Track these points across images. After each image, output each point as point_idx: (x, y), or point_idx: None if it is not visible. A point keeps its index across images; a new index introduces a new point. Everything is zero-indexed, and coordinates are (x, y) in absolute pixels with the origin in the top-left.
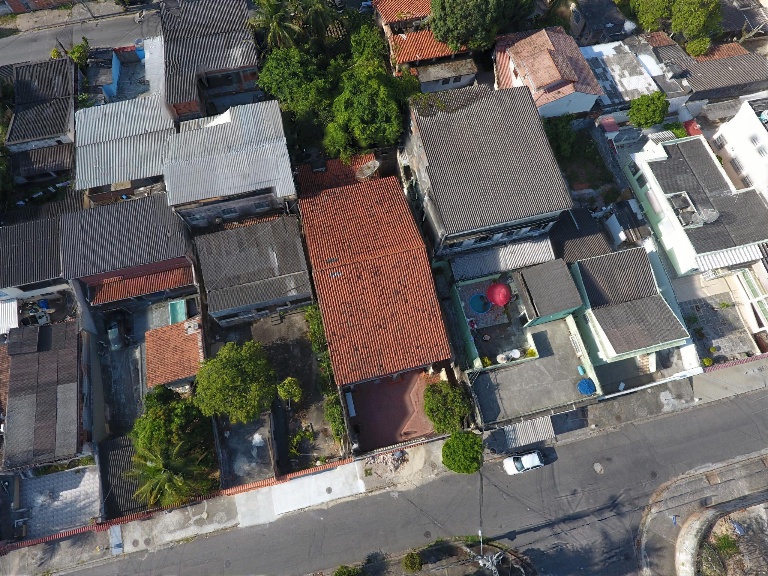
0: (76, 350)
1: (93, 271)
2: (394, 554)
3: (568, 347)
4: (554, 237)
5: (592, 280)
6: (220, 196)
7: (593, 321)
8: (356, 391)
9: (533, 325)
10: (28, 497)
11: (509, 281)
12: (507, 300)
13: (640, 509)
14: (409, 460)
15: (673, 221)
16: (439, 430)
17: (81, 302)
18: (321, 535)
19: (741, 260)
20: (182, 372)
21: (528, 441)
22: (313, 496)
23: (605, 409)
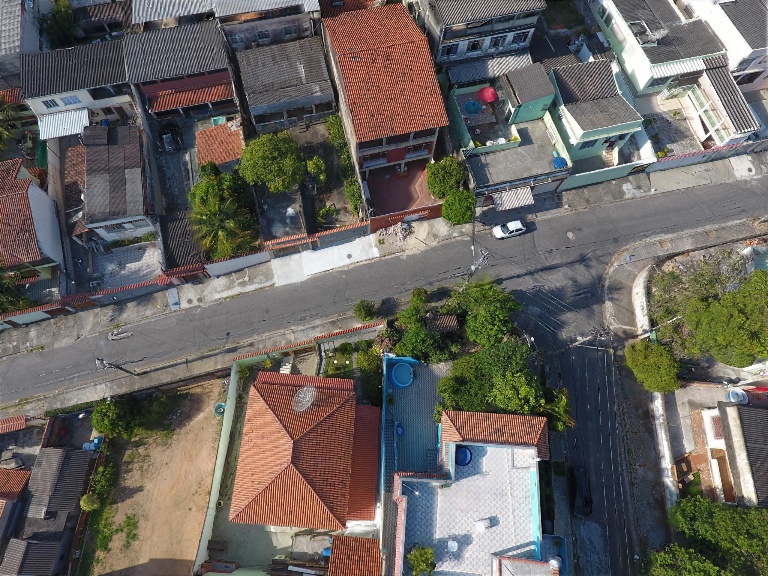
0: (138, 146)
1: (153, 77)
2: (404, 298)
3: (545, 138)
4: (534, 57)
5: (564, 83)
6: (258, 10)
7: (565, 114)
8: (370, 182)
9: (516, 123)
10: (100, 268)
11: (497, 92)
12: (494, 98)
13: (604, 264)
14: (415, 232)
15: (633, 43)
16: (439, 194)
17: (141, 109)
18: (343, 287)
19: (688, 70)
20: (228, 157)
21: (512, 206)
22: (336, 261)
23: (577, 195)
